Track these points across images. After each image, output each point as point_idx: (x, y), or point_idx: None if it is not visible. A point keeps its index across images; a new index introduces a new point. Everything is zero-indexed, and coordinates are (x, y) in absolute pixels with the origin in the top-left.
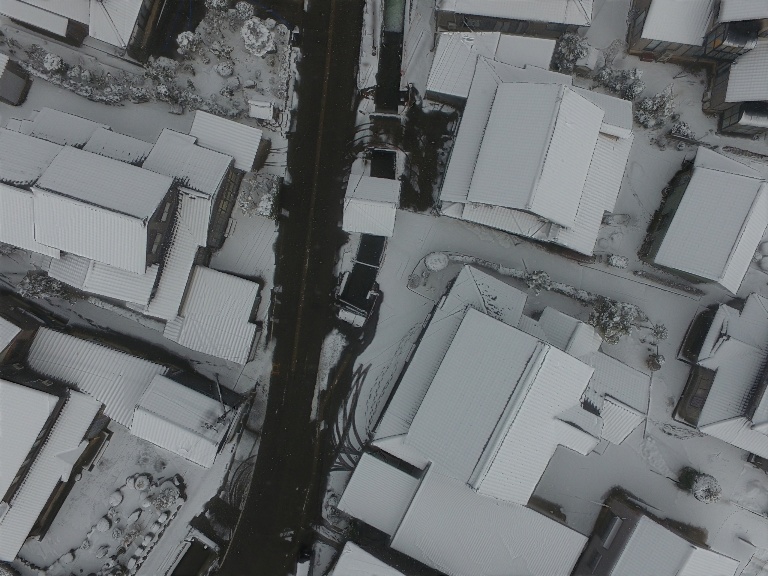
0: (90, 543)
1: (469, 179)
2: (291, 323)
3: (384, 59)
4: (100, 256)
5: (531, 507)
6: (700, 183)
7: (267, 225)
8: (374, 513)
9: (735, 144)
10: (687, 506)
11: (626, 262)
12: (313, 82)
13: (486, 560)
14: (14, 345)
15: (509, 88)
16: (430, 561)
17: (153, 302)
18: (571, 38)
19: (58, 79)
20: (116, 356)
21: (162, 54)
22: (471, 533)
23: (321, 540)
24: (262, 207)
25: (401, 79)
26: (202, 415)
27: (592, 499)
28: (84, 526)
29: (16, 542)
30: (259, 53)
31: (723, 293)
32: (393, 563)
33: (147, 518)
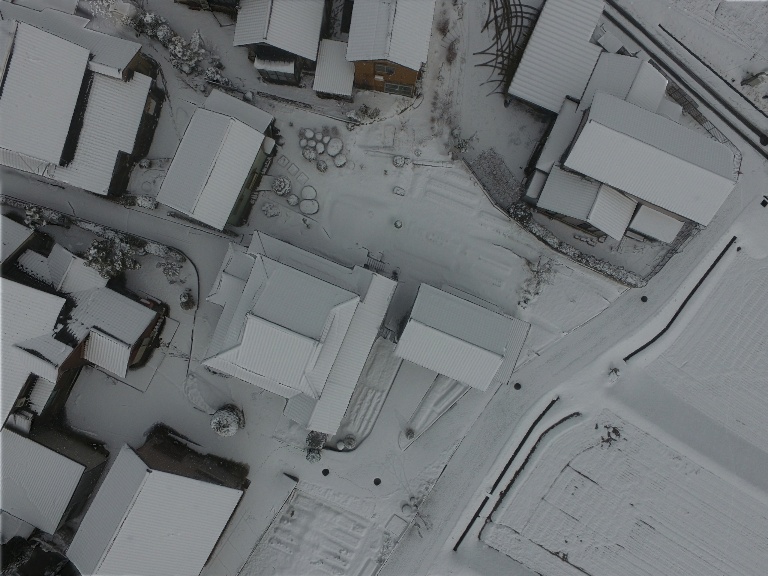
0: None
1: None
2: None
3: None
4: None
5: (31, 438)
6: (195, 122)
7: None
8: None
9: (282, 91)
10: (229, 442)
11: (152, 203)
12: None
13: None
14: None
15: None
16: None
17: None
18: None
19: None
20: None
21: None
22: None
23: None
24: None
25: None
26: None
27: (134, 435)
28: None
29: None
30: None
31: None
32: None
33: None
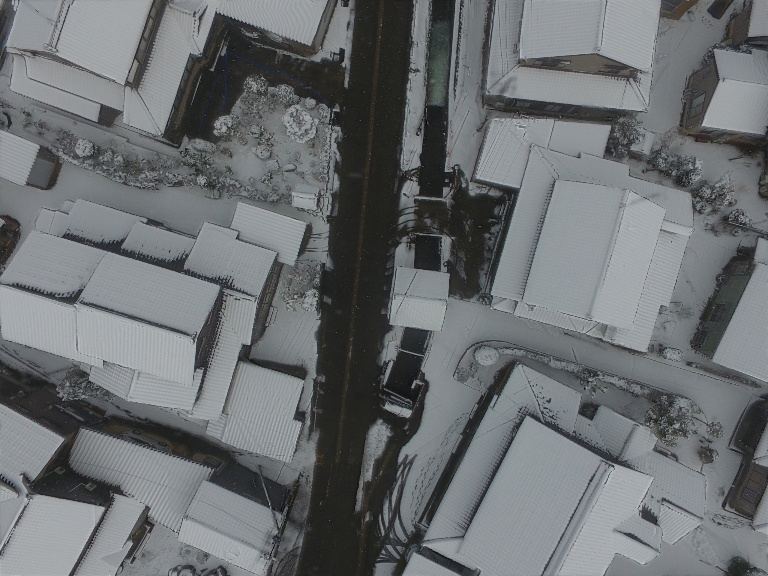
0: None
1: (523, 276)
2: (334, 413)
3: (428, 138)
4: (146, 368)
5: None
6: (762, 281)
7: (309, 313)
8: None
9: None
10: None
11: (680, 355)
12: (355, 163)
13: None
14: None
15: (568, 187)
16: None
17: (197, 404)
18: (626, 122)
19: (90, 165)
20: (159, 458)
21: (197, 136)
22: None
23: None
24: (307, 303)
25: (446, 160)
26: (251, 523)
27: None
28: None
29: None
30: (301, 140)
31: None
32: None
33: None
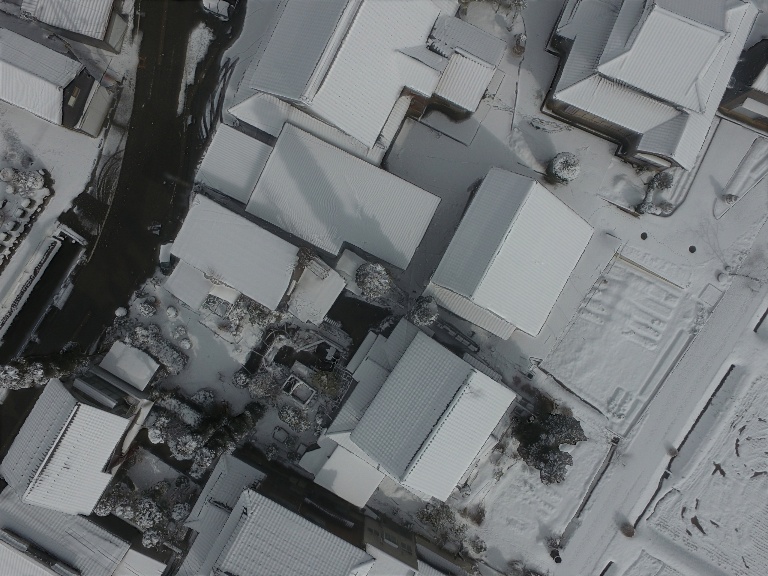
0: None
1: None
2: (157, 16)
3: None
4: None
5: None
6: None
7: None
8: (231, 183)
9: None
10: None
11: None
12: None
13: (329, 199)
14: None
15: None
16: (284, 224)
17: None
18: None
19: None
20: None
21: None
22: (314, 172)
23: None
24: None
25: None
26: (48, 64)
27: (458, 190)
28: None
29: None
30: None
31: None
32: (242, 214)
33: (12, 208)
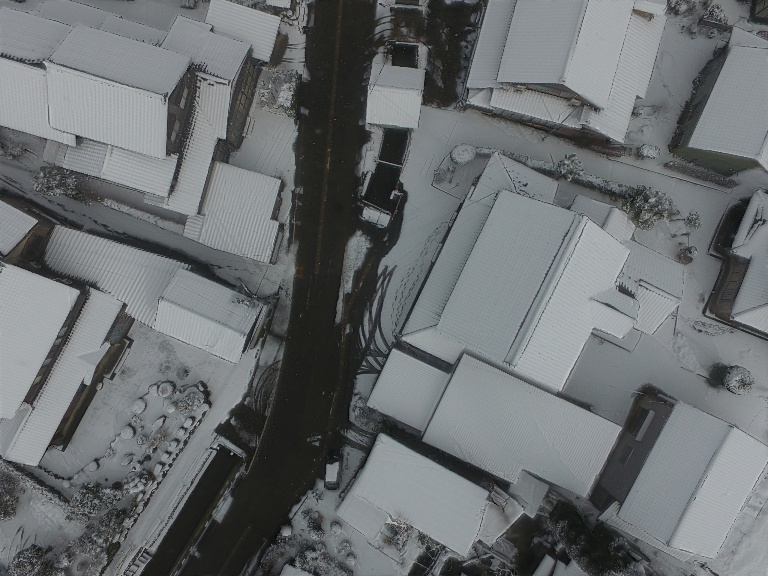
0: (114, 451)
1: (498, 62)
2: (313, 225)
3: None
4: (118, 140)
5: (564, 398)
6: (736, 62)
7: (286, 124)
8: (404, 409)
9: None
10: (717, 402)
11: (658, 152)
12: None
13: (521, 445)
14: (31, 239)
15: None
16: (462, 454)
17: (173, 196)
18: None
19: None
20: (136, 254)
21: None
22: (506, 418)
23: (349, 444)
24: (283, 97)
25: None
26: (228, 307)
27: (622, 397)
28: (107, 435)
29: (40, 446)
30: None
31: (755, 185)
32: (426, 454)
33: (172, 425)
